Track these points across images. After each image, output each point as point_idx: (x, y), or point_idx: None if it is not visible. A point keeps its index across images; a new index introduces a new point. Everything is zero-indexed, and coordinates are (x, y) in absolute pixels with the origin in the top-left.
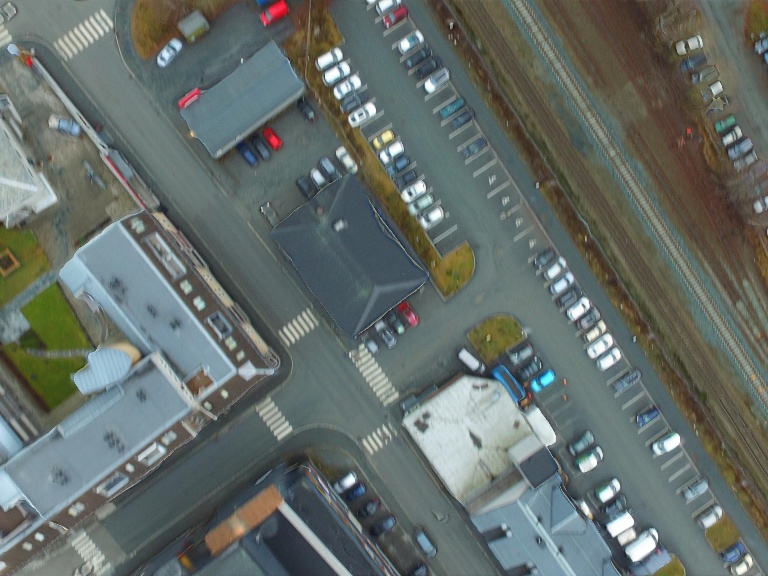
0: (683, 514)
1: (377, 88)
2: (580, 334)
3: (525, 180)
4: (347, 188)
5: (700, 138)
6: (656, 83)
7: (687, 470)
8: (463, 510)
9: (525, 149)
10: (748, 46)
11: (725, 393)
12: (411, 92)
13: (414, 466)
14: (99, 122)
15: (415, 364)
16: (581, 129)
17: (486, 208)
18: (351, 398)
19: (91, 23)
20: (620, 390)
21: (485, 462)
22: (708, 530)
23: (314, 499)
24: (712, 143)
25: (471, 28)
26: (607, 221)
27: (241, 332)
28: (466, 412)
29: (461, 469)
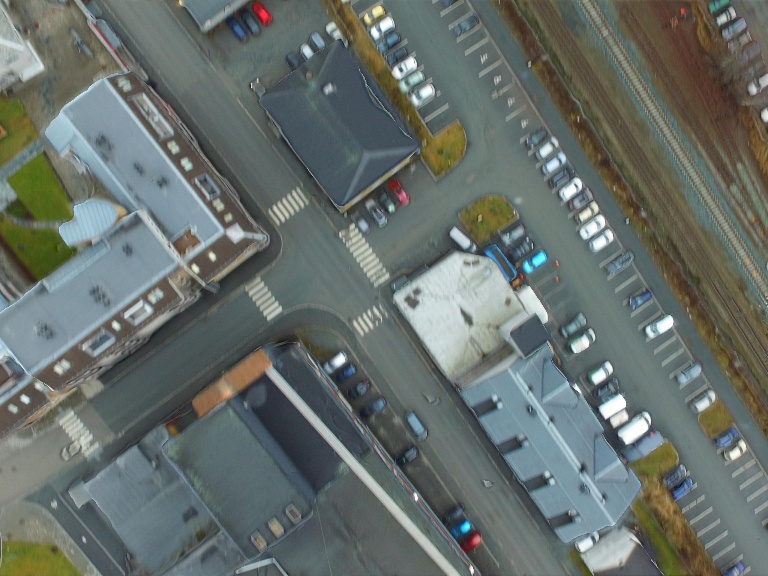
0: (676, 399)
1: None
2: (572, 215)
3: (517, 59)
4: (336, 53)
5: (694, 17)
6: None
7: (680, 354)
8: (454, 392)
9: (517, 27)
10: None
11: (719, 277)
12: None
13: (405, 348)
14: None
15: (406, 244)
16: (574, 8)
17: (478, 87)
18: (341, 278)
19: None
20: (613, 273)
21: (476, 339)
22: (701, 415)
23: (303, 368)
24: (706, 24)
25: None
26: (600, 101)
27: (229, 196)
28: (457, 289)
29: (452, 346)
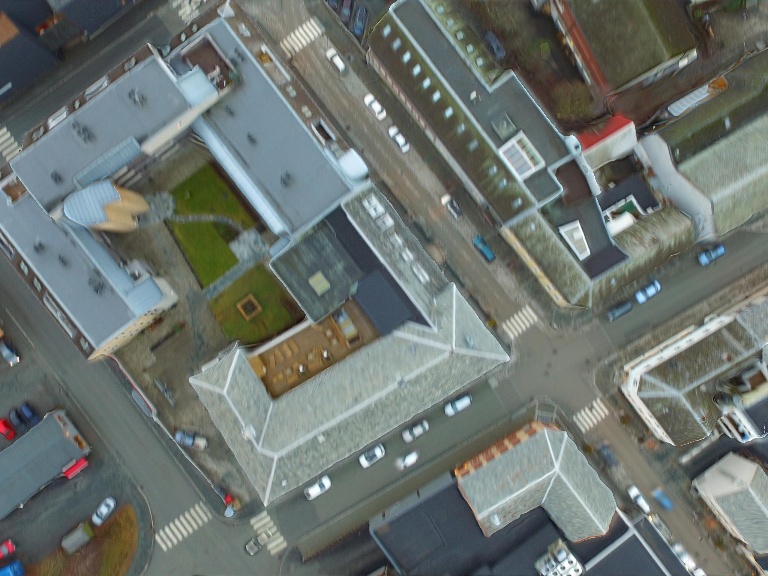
0: None
1: None
2: None
3: None
4: None
5: None
6: None
7: None
8: None
9: None
10: None
11: None
12: None
13: None
14: (173, 443)
15: None
16: None
17: None
18: None
19: (177, 538)
20: None
21: None
22: None
23: None
24: None
25: None
26: None
27: None
28: None
29: None
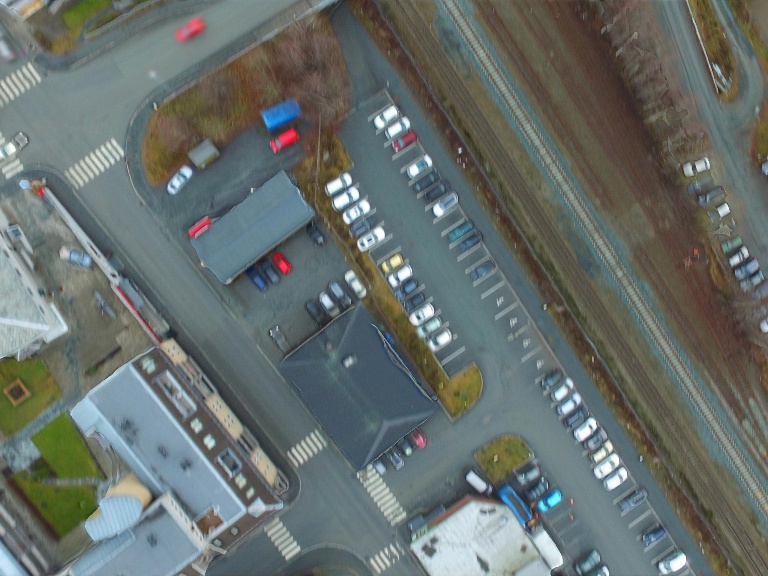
0: None
1: (386, 212)
2: (587, 454)
3: (533, 301)
4: (356, 322)
5: (707, 260)
6: (663, 204)
7: None
8: None
9: (533, 271)
10: (755, 167)
11: (731, 511)
12: (420, 215)
13: None
14: (110, 249)
15: (423, 484)
16: (588, 250)
17: (494, 329)
18: (359, 518)
19: (102, 152)
20: (626, 509)
21: None
22: None
23: None
24: (719, 263)
25: (479, 151)
26: (614, 341)
27: (251, 467)
28: (473, 536)
29: None
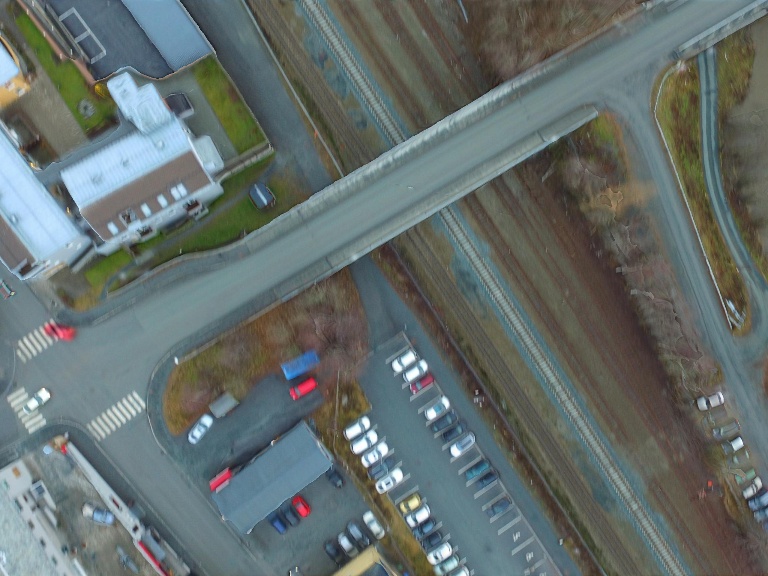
0: None
1: (404, 452)
2: None
3: (549, 536)
4: None
5: (721, 494)
6: (678, 438)
7: None
8: None
9: (549, 506)
10: (767, 398)
11: None
12: (437, 455)
13: None
14: (131, 497)
15: None
16: (604, 484)
17: (510, 565)
18: None
19: (124, 404)
20: None
21: None
22: None
23: None
24: (733, 495)
25: (496, 389)
26: (629, 573)
27: None
28: None
29: None
